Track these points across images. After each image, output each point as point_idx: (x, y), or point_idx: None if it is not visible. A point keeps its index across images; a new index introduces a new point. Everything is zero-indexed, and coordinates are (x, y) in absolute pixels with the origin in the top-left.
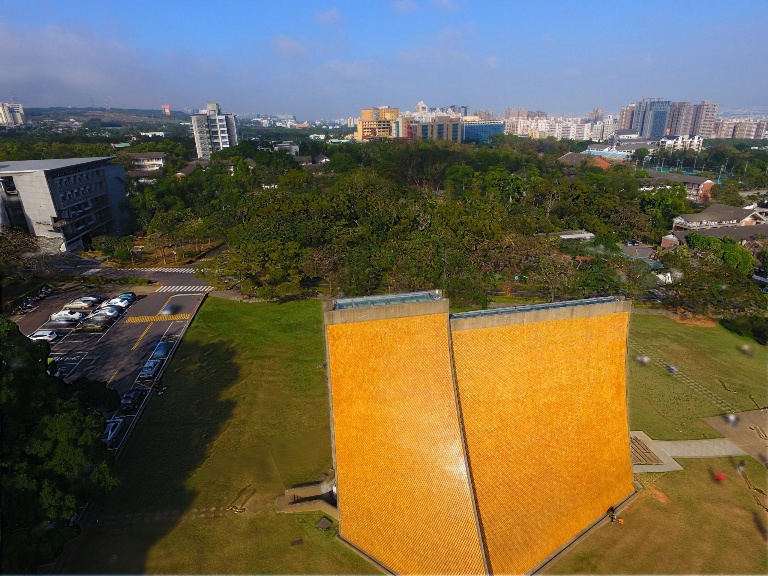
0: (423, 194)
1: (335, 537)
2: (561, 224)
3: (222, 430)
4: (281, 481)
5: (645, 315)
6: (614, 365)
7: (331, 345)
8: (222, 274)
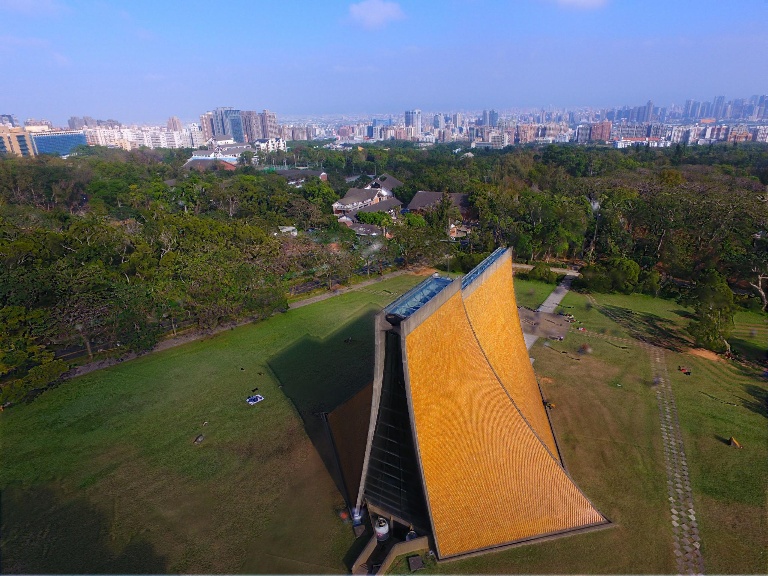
0: None
1: (437, 563)
2: None
3: None
4: (326, 568)
5: (395, 277)
6: (512, 299)
7: (409, 358)
8: None
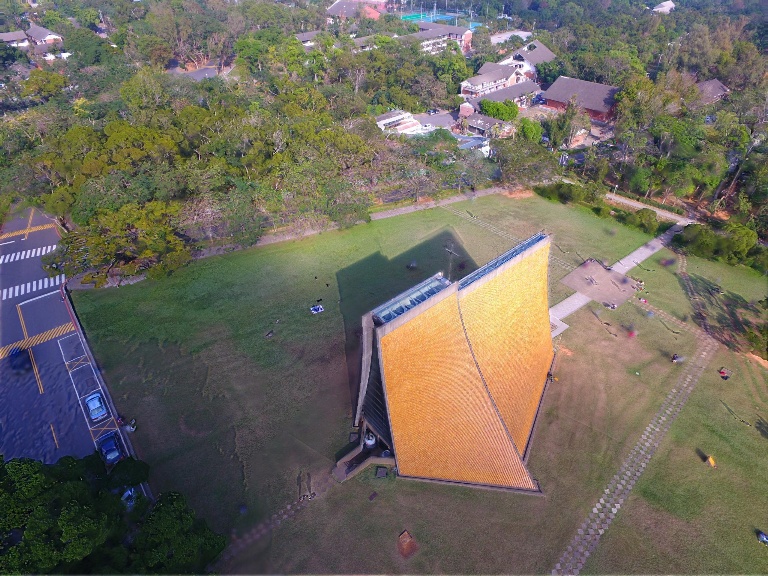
0: (224, 85)
1: (396, 478)
2: (368, 98)
3: (233, 437)
4: (323, 456)
5: (486, 196)
6: (542, 281)
7: (383, 351)
8: None
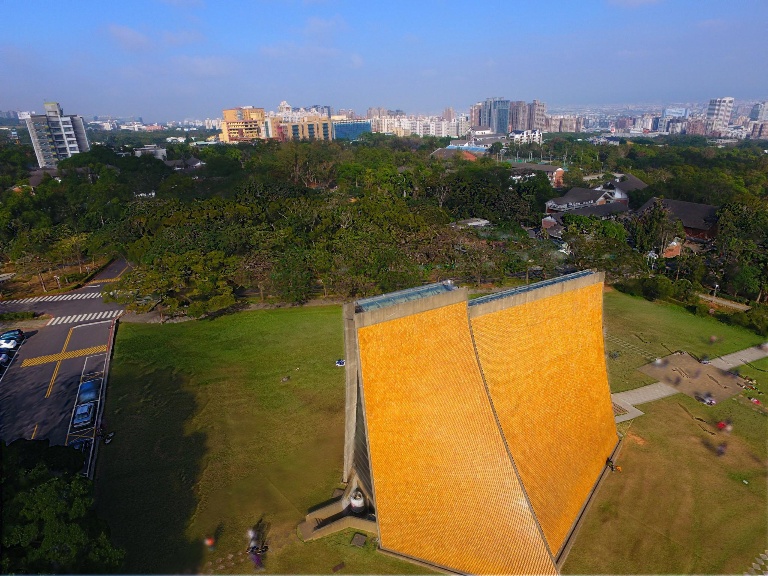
0: (321, 193)
1: (376, 550)
2: (452, 214)
3: (203, 468)
4: (294, 507)
5: None
6: (594, 331)
7: (362, 349)
8: (138, 295)
